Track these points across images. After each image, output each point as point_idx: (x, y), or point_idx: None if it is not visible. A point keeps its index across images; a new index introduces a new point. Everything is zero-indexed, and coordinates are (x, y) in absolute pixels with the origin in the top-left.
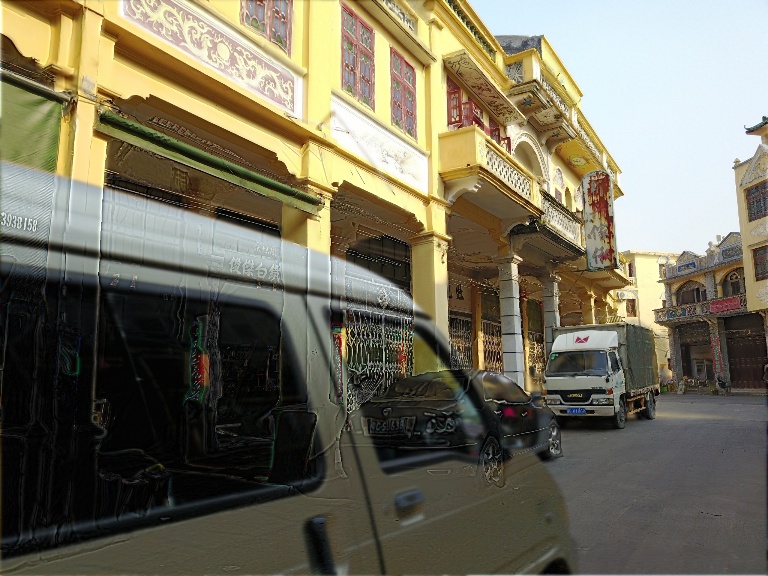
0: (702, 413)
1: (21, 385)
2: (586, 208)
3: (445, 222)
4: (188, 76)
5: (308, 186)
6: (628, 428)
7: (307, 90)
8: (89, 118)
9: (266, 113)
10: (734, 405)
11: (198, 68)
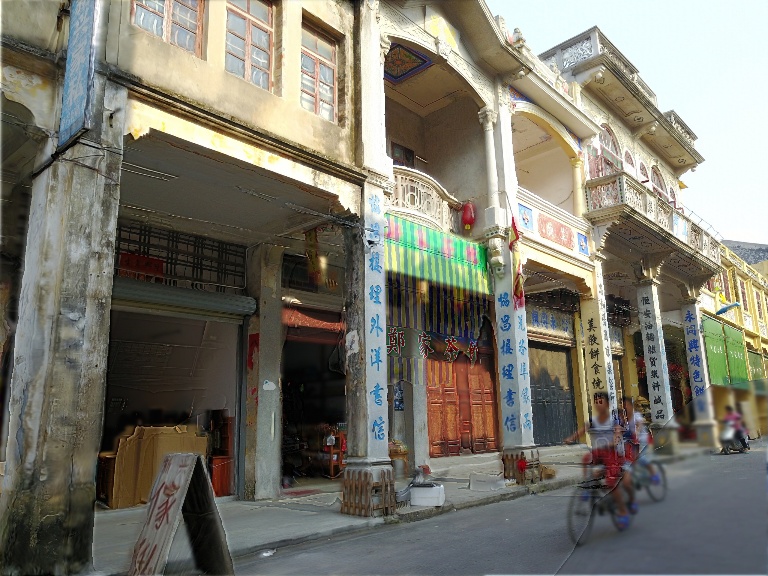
0: None
1: None
2: None
3: None
4: None
5: None
6: None
7: (767, 329)
8: None
9: (767, 340)
10: None
11: None
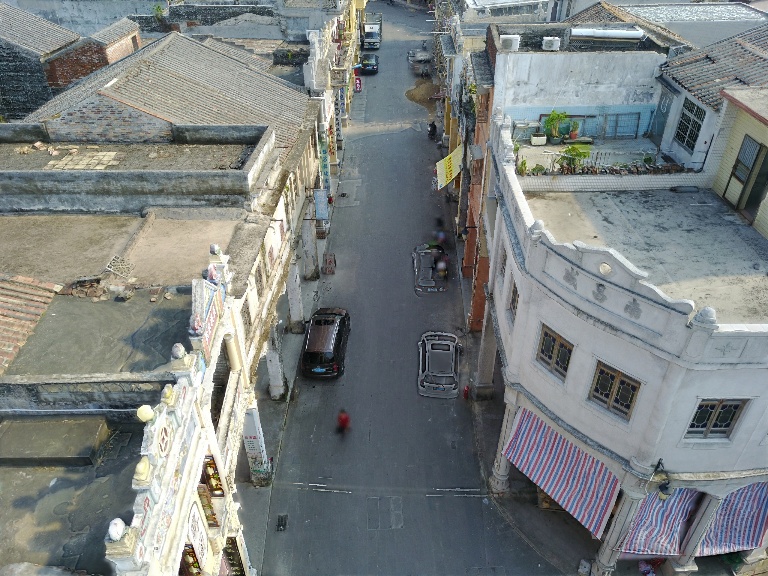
0: (391, 34)
1: None
2: None
3: None
4: None
5: None
6: None
7: None
8: None
9: None
10: (397, 25)
11: None
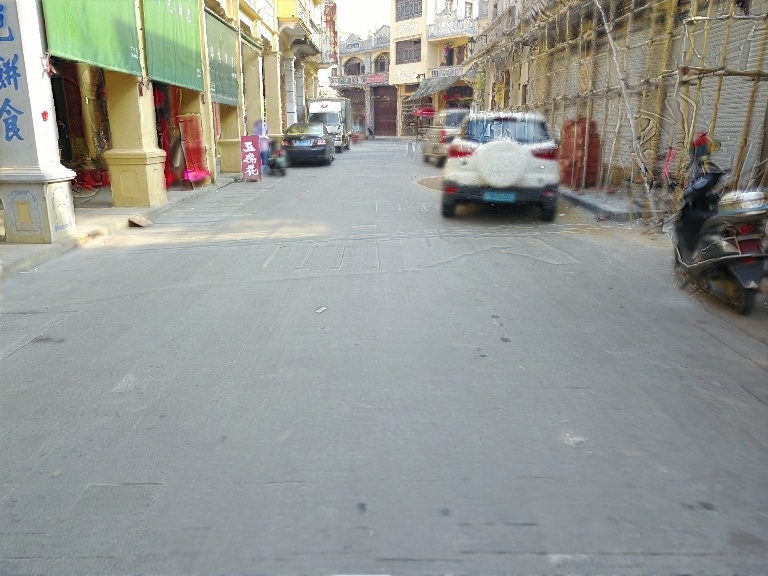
0: (369, 147)
1: (232, 126)
2: (322, 23)
3: (278, 44)
4: (241, 4)
5: (258, 41)
6: (344, 152)
7: None
8: (240, 36)
9: None
10: (381, 144)
11: (247, 3)
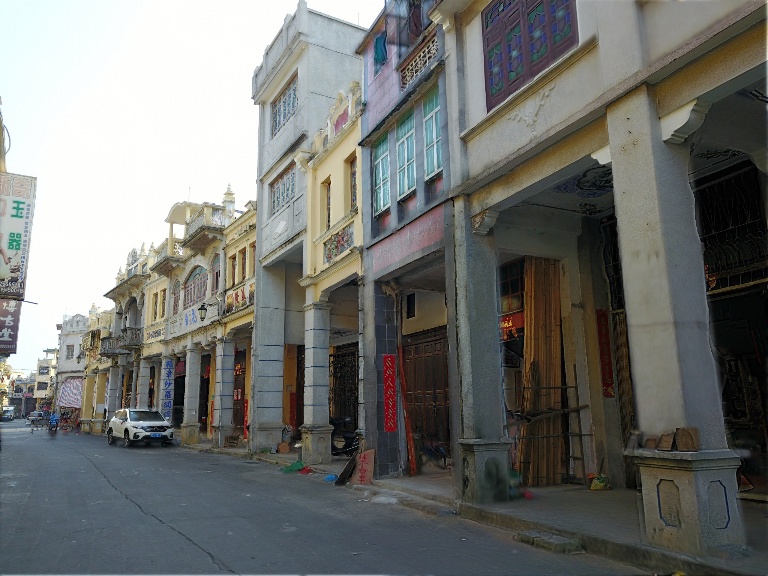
0: None
1: None
2: (10, 385)
3: None
4: None
5: None
6: None
7: None
8: None
9: None
10: None
11: None
